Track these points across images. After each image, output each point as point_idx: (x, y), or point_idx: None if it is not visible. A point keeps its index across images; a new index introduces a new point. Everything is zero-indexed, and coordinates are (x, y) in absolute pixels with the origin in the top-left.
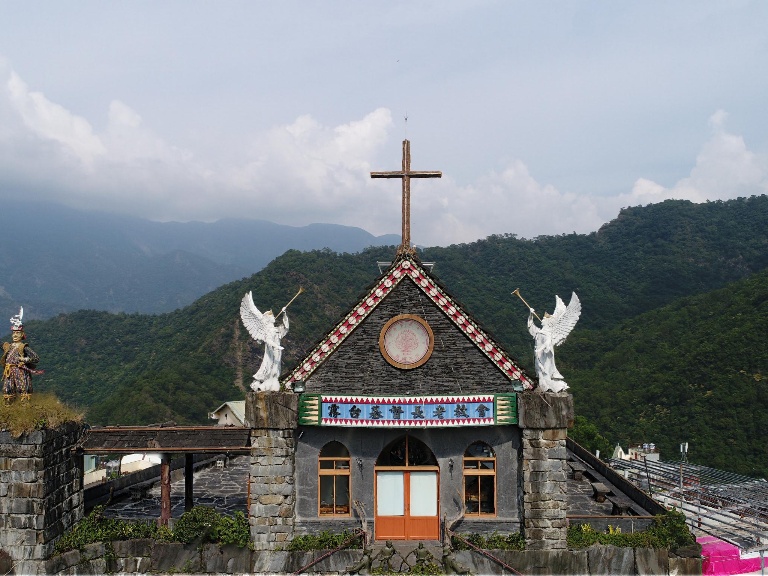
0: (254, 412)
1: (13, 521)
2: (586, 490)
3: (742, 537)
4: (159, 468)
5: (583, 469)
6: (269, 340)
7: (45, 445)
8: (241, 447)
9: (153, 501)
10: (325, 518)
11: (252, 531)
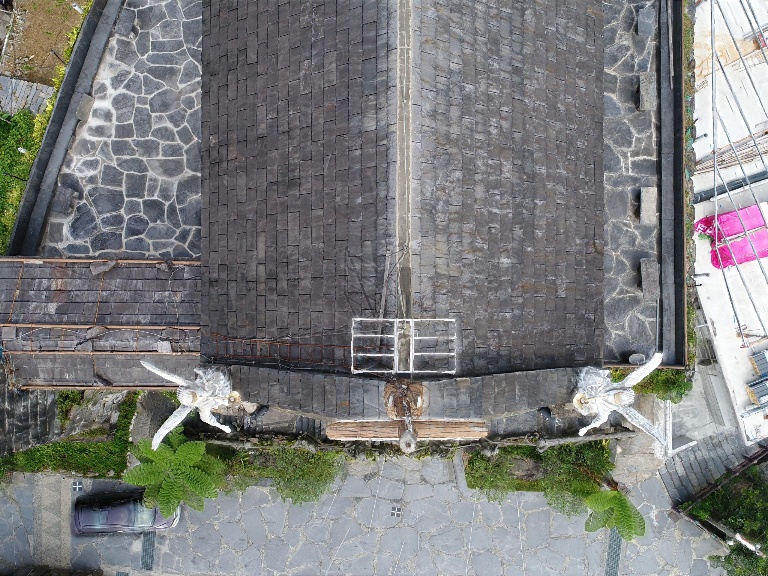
0: None
1: None
2: (637, 162)
3: (759, 318)
4: (57, 114)
5: (653, 109)
6: None
7: None
8: None
9: (90, 213)
10: None
11: None
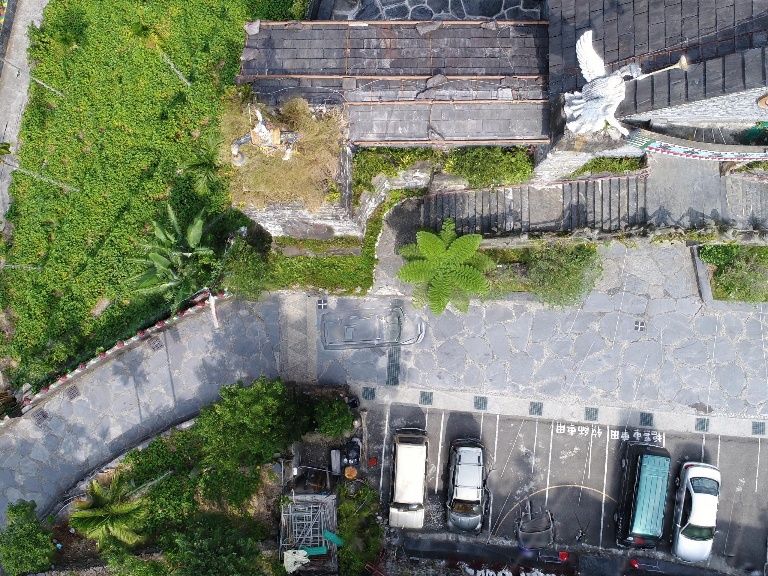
0: None
1: None
2: None
3: None
4: None
5: None
6: (611, 120)
7: (340, 199)
8: (538, 140)
9: (374, 4)
10: None
11: None
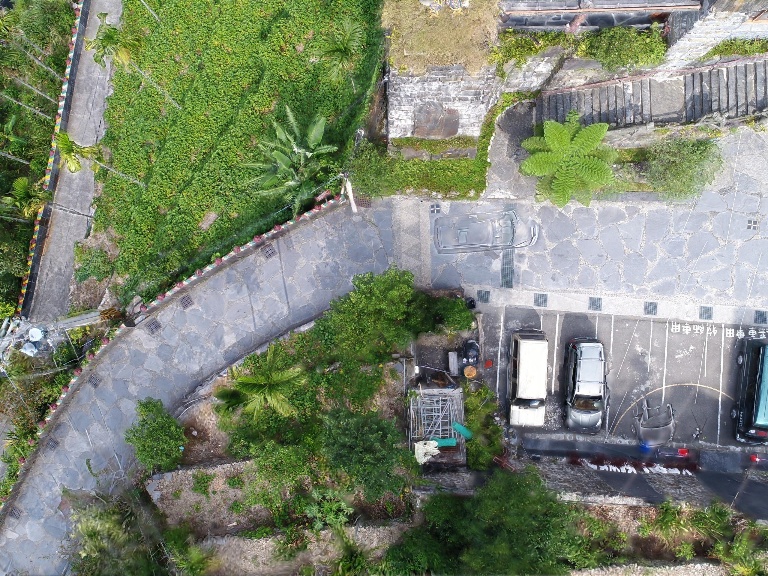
0: (727, 3)
1: (460, 99)
2: None
3: None
4: None
5: None
6: None
7: None
8: (689, 6)
9: None
10: (743, 27)
11: (669, 52)
